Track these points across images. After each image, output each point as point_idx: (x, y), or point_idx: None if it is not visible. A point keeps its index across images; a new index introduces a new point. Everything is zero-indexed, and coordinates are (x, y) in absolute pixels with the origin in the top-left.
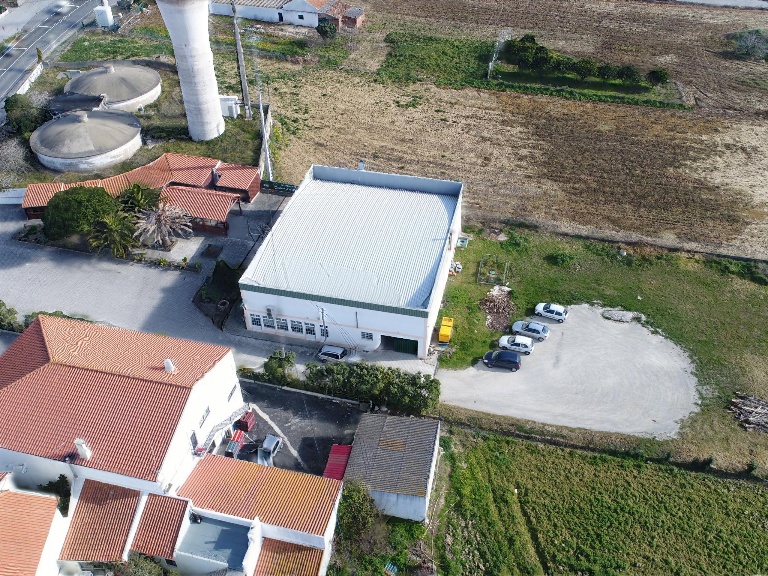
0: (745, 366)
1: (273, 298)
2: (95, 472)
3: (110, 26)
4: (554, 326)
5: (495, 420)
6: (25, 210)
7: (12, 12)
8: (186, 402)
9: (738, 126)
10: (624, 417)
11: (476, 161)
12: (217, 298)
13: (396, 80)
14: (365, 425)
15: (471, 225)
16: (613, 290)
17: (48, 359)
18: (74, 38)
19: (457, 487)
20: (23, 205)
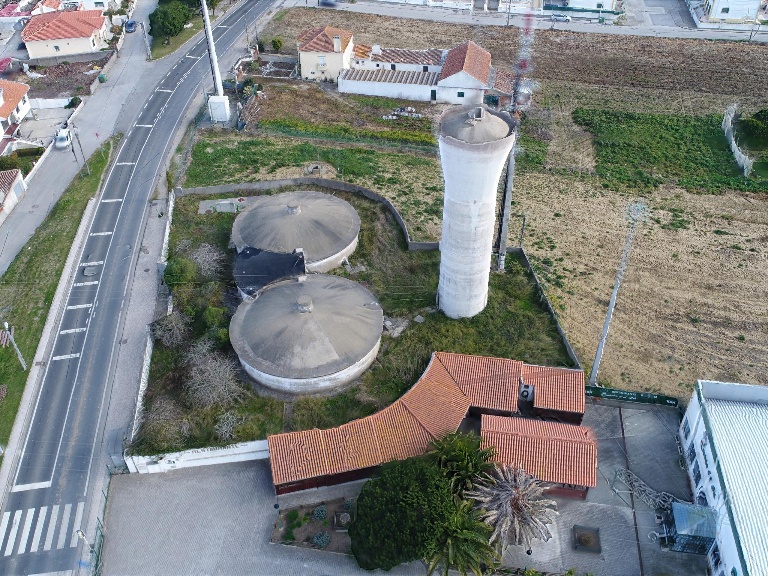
0: None
1: None
2: None
3: (228, 121)
4: None
5: None
6: (276, 485)
7: (87, 103)
8: None
9: None
10: None
11: None
12: None
13: (632, 184)
14: None
15: None
16: None
17: None
18: (190, 142)
19: None
20: (275, 480)
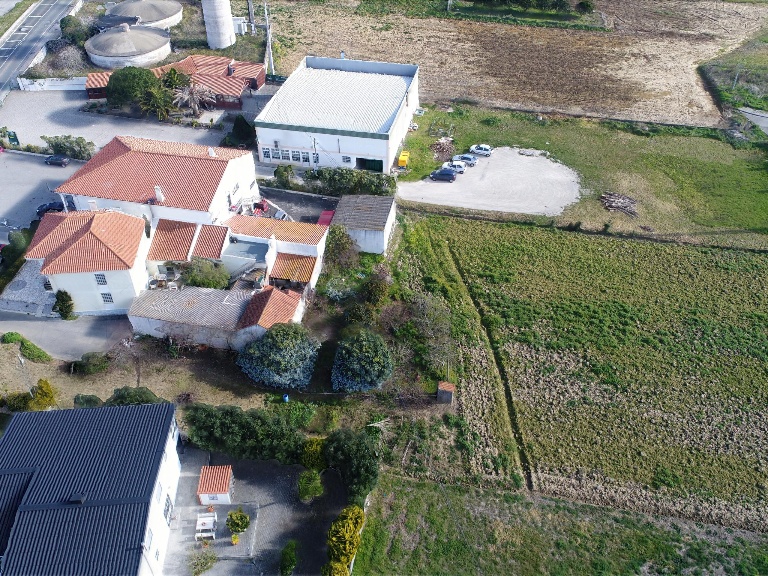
0: (616, 179)
1: (279, 132)
2: (167, 211)
3: None
4: (483, 159)
5: (436, 207)
6: (87, 91)
7: None
8: (225, 169)
9: (645, 42)
10: (526, 205)
11: (434, 65)
12: (237, 143)
13: (373, 12)
14: (344, 200)
15: (427, 103)
16: (529, 139)
17: (130, 150)
18: None
19: (407, 239)
20: (86, 87)
